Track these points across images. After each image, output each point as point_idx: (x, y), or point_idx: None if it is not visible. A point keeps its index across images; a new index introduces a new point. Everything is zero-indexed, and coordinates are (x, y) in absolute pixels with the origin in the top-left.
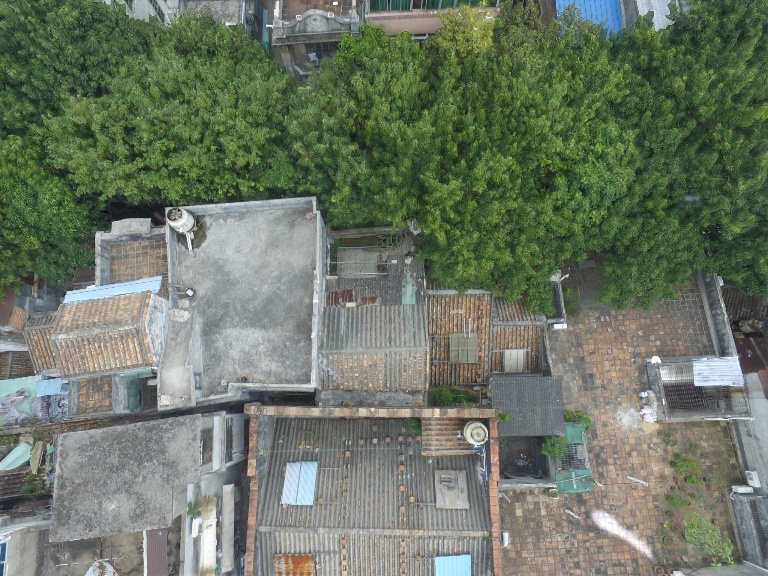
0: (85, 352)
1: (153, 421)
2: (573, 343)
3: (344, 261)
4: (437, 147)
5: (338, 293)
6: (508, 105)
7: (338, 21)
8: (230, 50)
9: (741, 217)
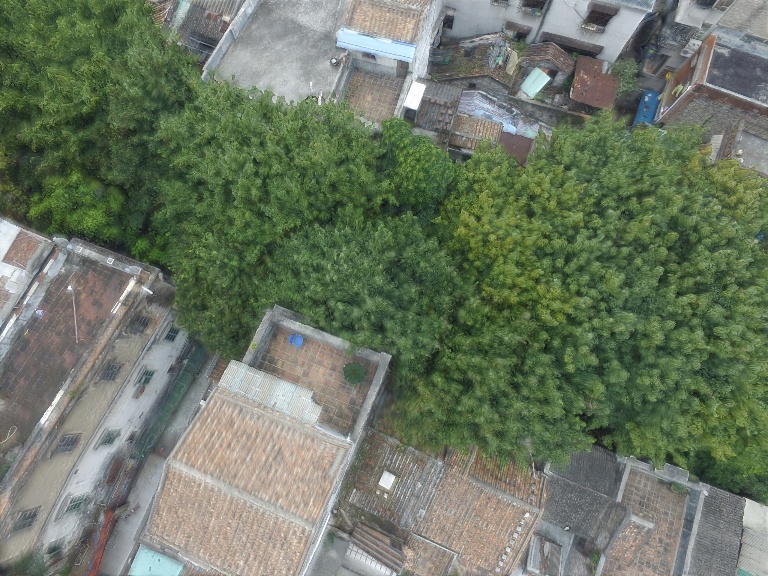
0: None
1: None
2: None
3: None
4: None
5: None
6: None
7: None
8: None
9: None
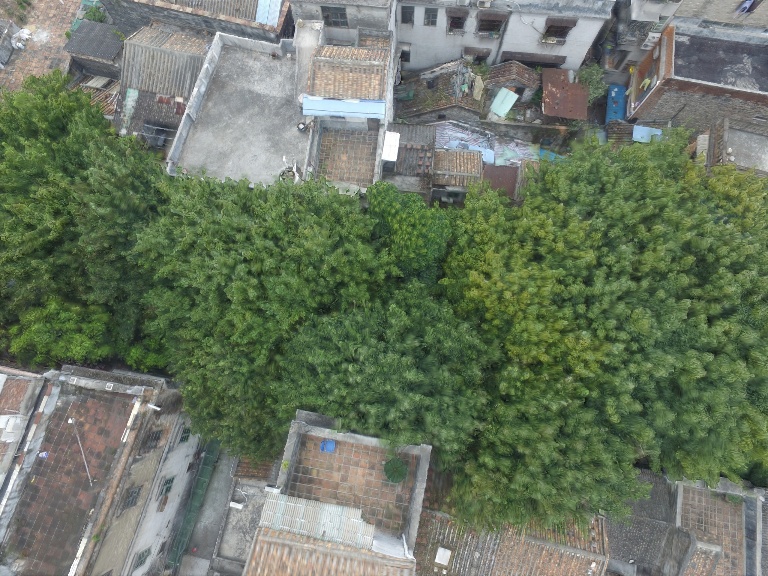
0: None
1: (319, 2)
2: None
3: None
4: None
5: None
6: None
7: None
8: None
9: None
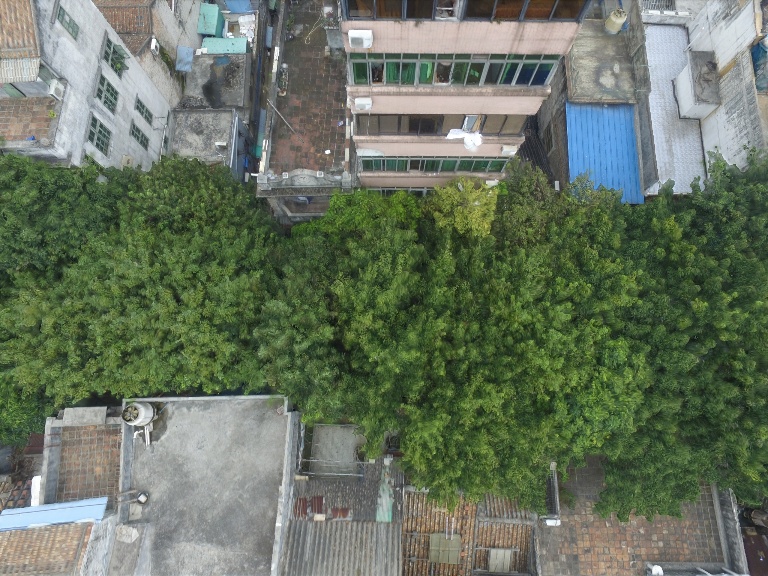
0: None
1: None
2: (567, 537)
3: (320, 439)
4: (423, 361)
5: (307, 500)
6: (504, 320)
7: (328, 179)
8: (209, 208)
9: (761, 457)
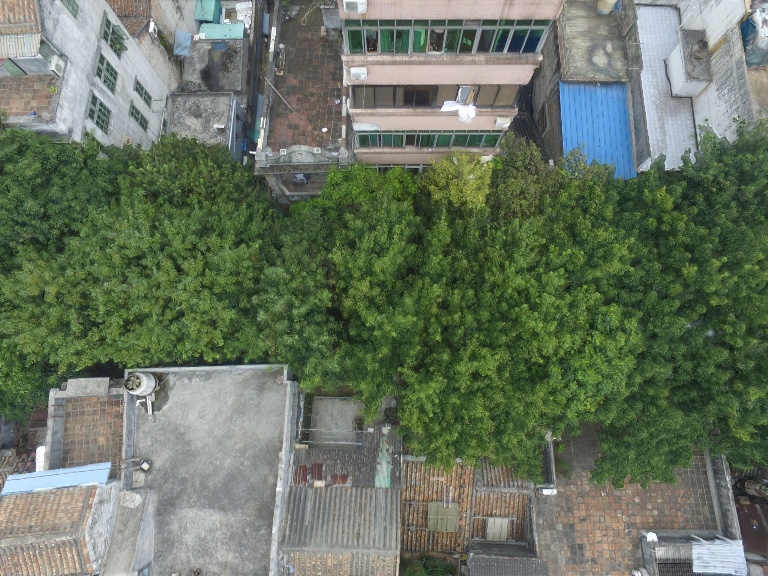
0: (18, 560)
1: None
2: (563, 507)
3: (320, 411)
4: (419, 327)
5: (307, 468)
6: (499, 286)
7: (325, 155)
8: (208, 184)
9: (751, 419)
